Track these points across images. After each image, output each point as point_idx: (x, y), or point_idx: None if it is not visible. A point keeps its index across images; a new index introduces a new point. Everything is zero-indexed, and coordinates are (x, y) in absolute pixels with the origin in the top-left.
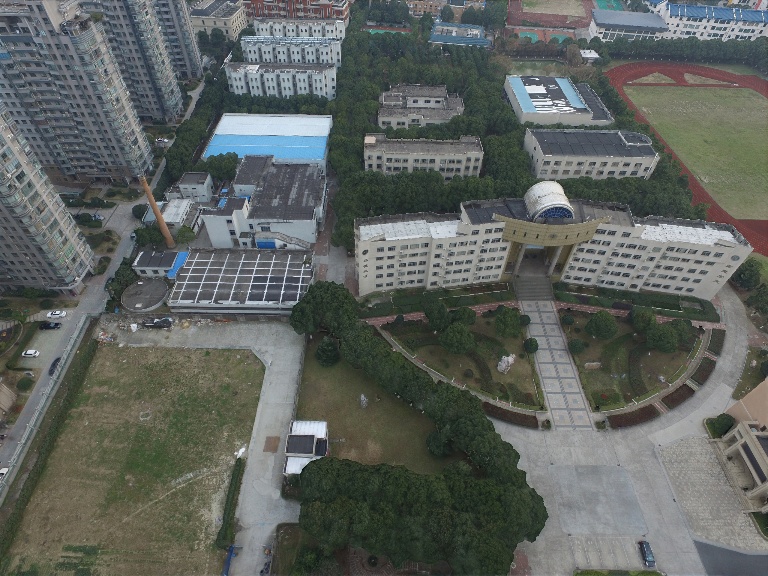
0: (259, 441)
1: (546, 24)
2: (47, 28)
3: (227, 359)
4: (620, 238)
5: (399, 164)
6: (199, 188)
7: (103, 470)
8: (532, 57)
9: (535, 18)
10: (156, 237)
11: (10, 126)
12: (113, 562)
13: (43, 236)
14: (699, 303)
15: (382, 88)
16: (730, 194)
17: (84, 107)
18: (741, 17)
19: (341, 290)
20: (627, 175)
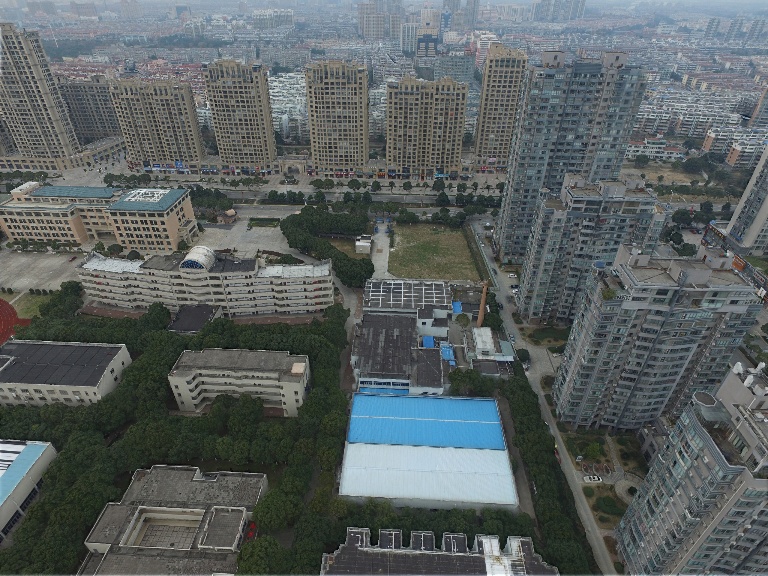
0: None
1: None
2: None
3: None
4: None
5: None
6: None
7: None
8: None
9: None
10: None
11: None
12: None
13: None
14: None
15: None
16: None
17: None
18: None
19: (345, 264)
20: None
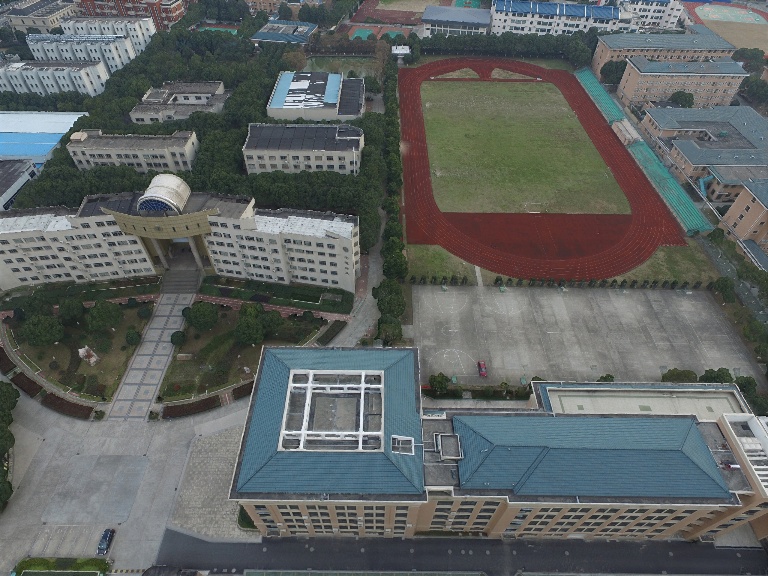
0: None
1: (389, 21)
2: None
3: None
4: (234, 230)
5: (104, 159)
6: None
7: None
8: (350, 53)
9: (382, 15)
10: None
11: None
12: None
13: None
14: (342, 295)
15: (160, 85)
16: (453, 187)
17: None
18: (564, 12)
19: None
20: (336, 169)
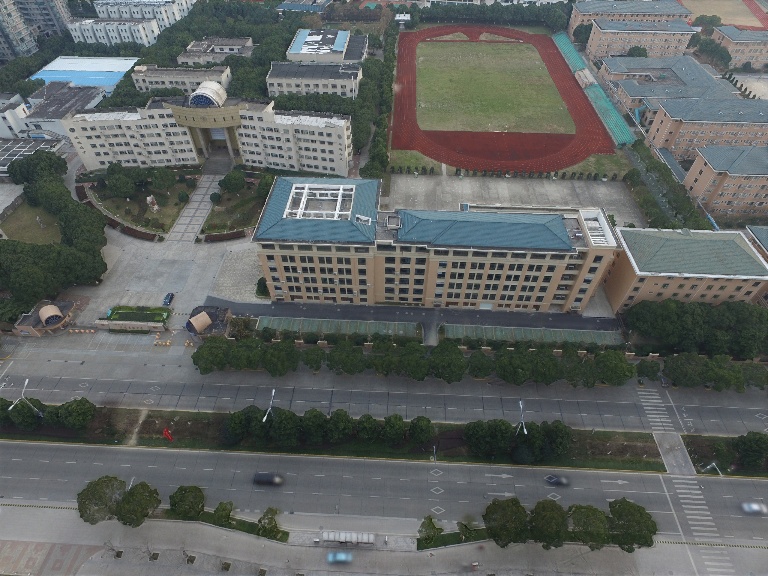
0: None
1: None
2: None
3: None
4: (258, 122)
5: (159, 86)
6: (7, 103)
7: None
8: (360, 21)
9: None
10: None
11: None
12: None
13: None
14: None
15: (201, 40)
16: (433, 114)
17: None
18: None
19: (47, 154)
20: None
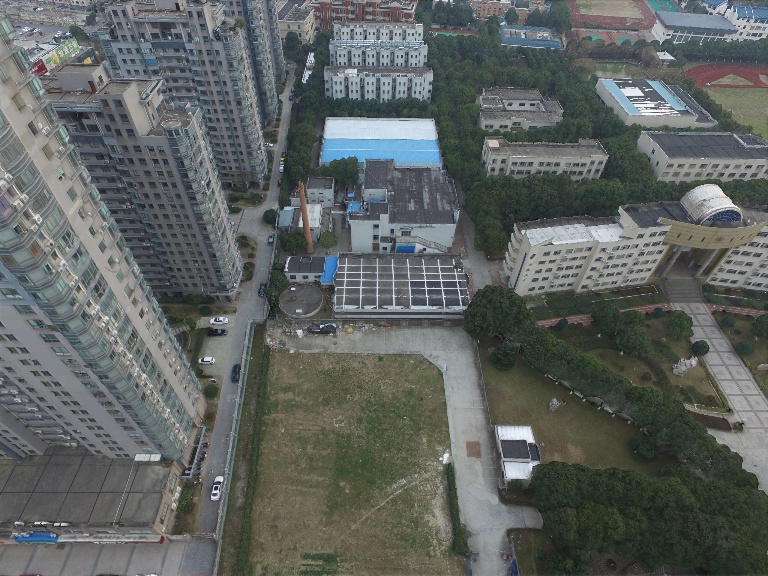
0: (460, 446)
1: (607, 26)
2: (202, 34)
3: (402, 364)
4: None
5: (523, 167)
6: (326, 193)
7: (315, 477)
8: (605, 59)
9: (595, 20)
10: (302, 242)
11: (203, 133)
12: (355, 569)
13: (218, 243)
14: None
15: (474, 91)
16: None
17: (221, 112)
18: None
19: (515, 294)
20: (747, 177)
